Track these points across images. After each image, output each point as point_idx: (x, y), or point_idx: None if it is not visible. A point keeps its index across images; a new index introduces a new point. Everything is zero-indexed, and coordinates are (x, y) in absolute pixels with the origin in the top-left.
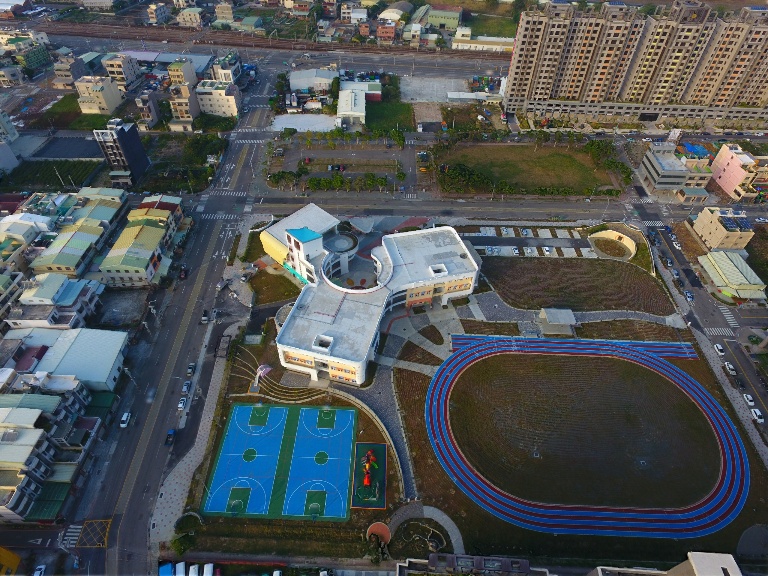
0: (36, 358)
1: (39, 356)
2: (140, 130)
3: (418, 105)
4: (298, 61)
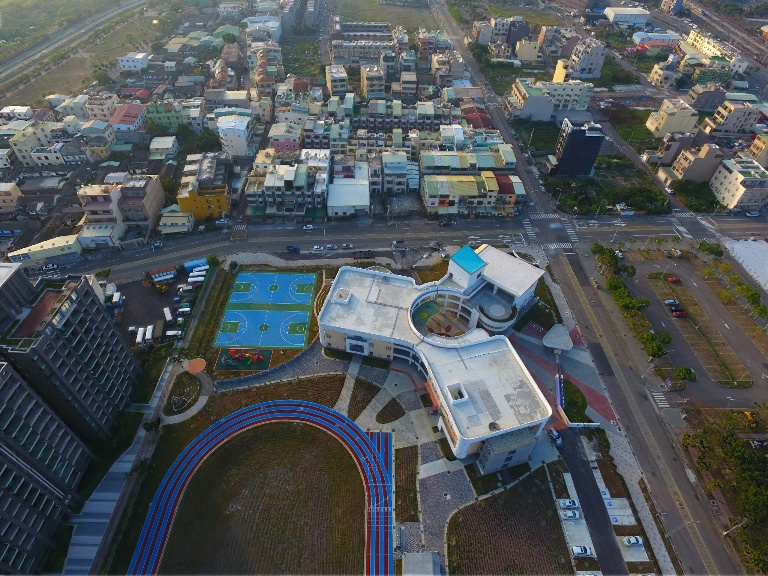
0: (344, 175)
1: (346, 176)
2: (642, 158)
3: None
4: None
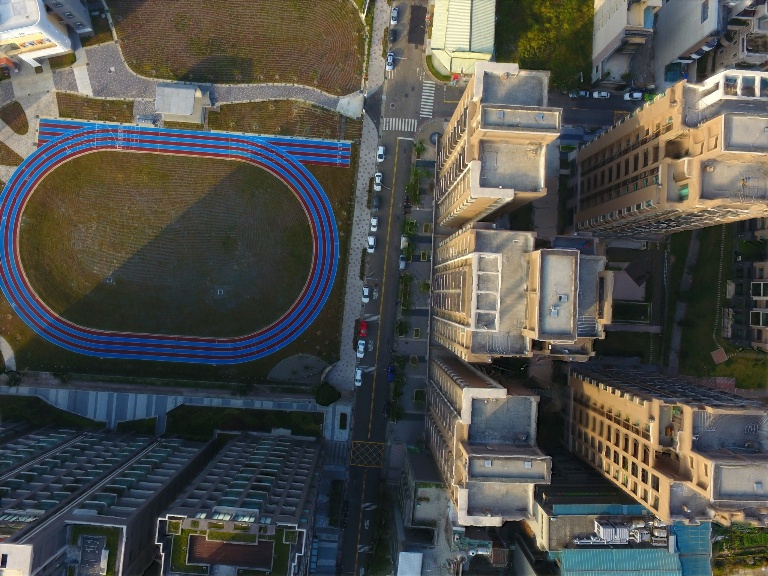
0: None
1: None
2: None
3: None
4: None
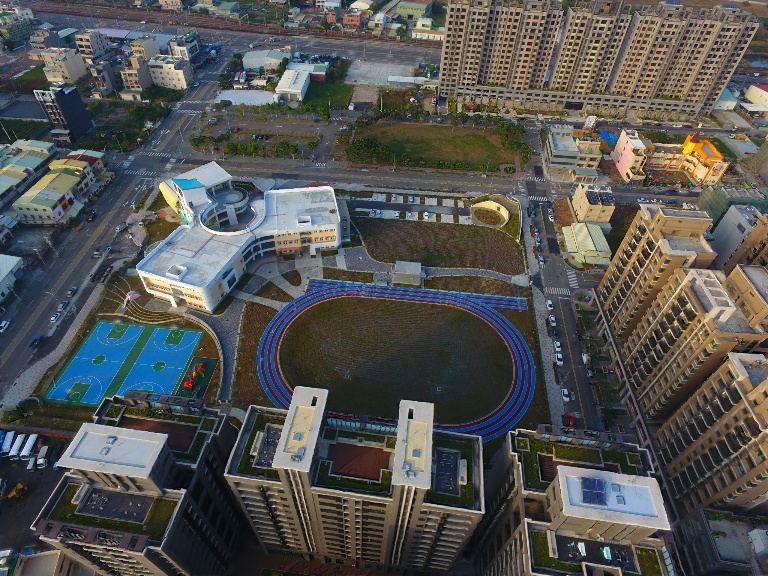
0: None
1: None
2: (95, 98)
3: (359, 87)
4: (261, 44)
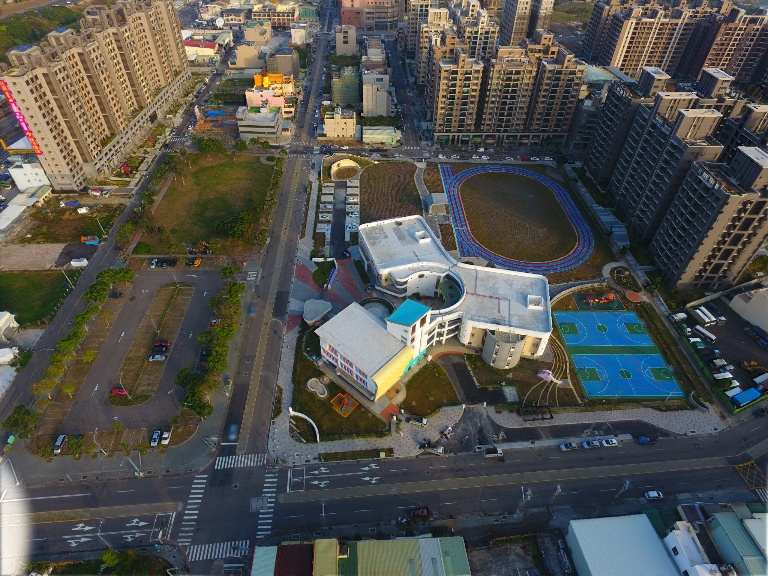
0: None
1: None
2: None
3: None
4: None
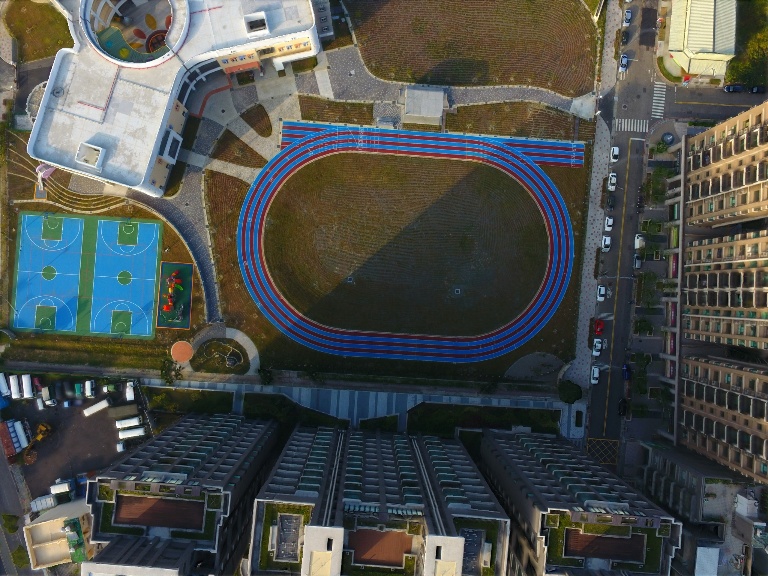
0: None
1: None
2: None
3: None
4: None
